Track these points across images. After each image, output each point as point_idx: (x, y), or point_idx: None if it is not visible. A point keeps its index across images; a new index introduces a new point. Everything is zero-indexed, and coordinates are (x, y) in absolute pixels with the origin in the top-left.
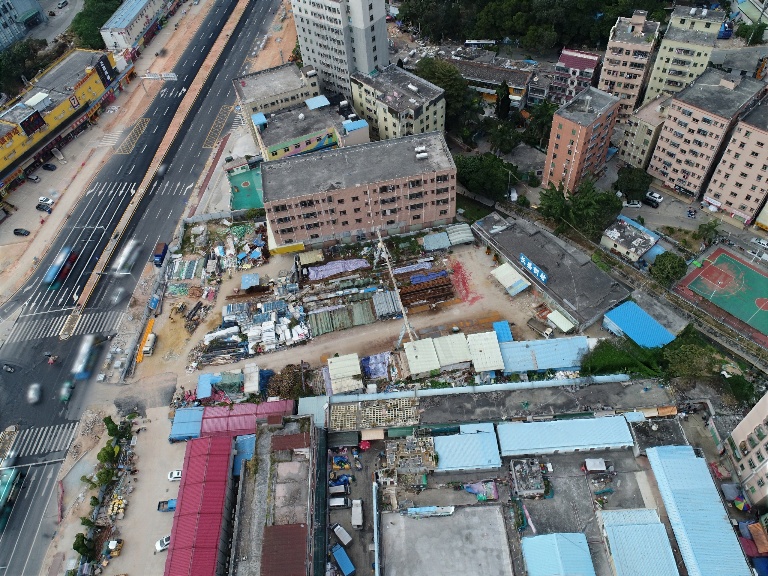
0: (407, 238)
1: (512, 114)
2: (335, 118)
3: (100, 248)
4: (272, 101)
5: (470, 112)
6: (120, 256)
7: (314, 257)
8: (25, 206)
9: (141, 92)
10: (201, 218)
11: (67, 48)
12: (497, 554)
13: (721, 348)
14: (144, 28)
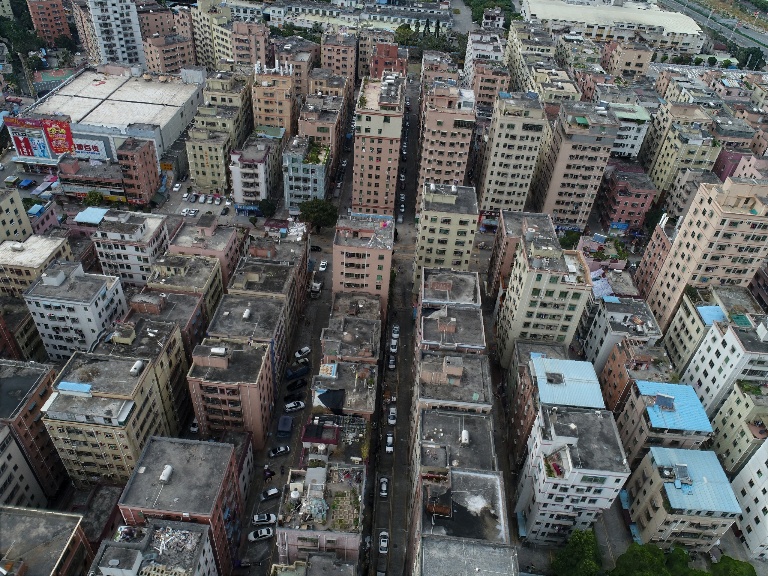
0: None
1: None
2: None
3: None
4: None
5: (23, 6)
6: None
7: None
8: None
9: None
10: None
11: None
12: None
13: (27, 89)
14: None
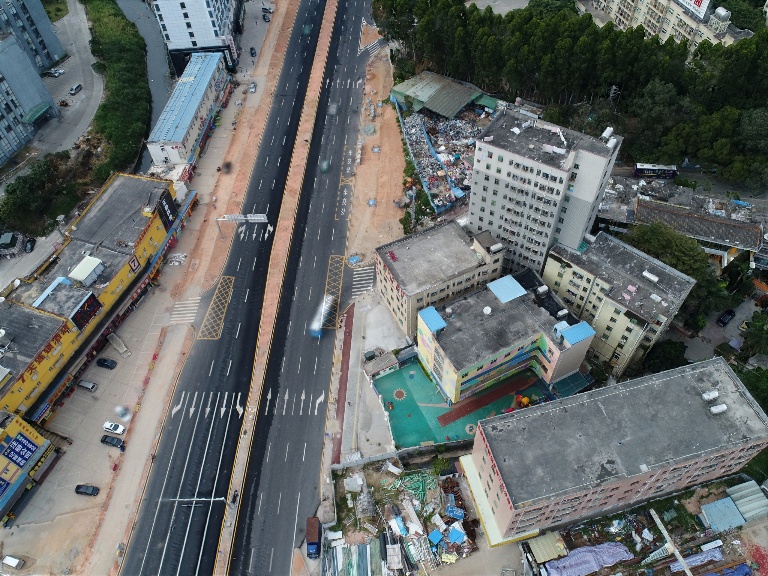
0: (668, 501)
1: (741, 284)
2: (535, 313)
3: (215, 521)
4: (443, 287)
5: (714, 299)
6: (249, 537)
7: (553, 547)
8: (82, 436)
9: (212, 231)
10: (355, 463)
11: (93, 157)
12: None
13: None
14: (199, 133)
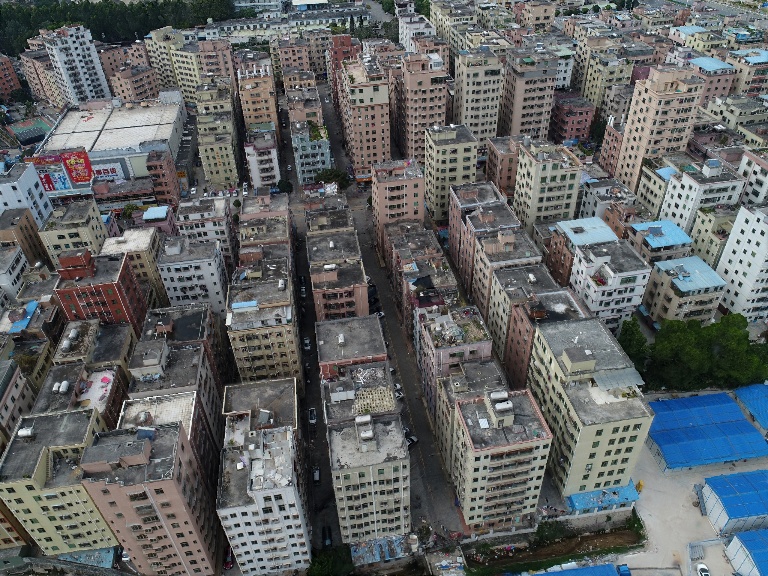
0: None
1: None
2: None
3: None
4: None
5: None
6: None
7: None
8: None
9: None
10: None
11: None
12: None
13: (3, 143)
14: None
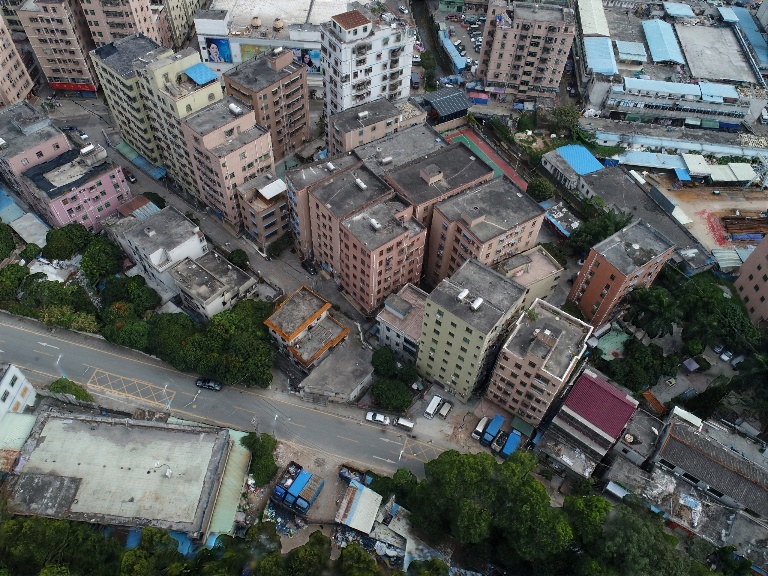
0: None
1: None
2: None
3: None
4: None
5: None
6: None
7: None
8: None
9: None
10: None
11: None
12: (695, 66)
13: None
14: None
